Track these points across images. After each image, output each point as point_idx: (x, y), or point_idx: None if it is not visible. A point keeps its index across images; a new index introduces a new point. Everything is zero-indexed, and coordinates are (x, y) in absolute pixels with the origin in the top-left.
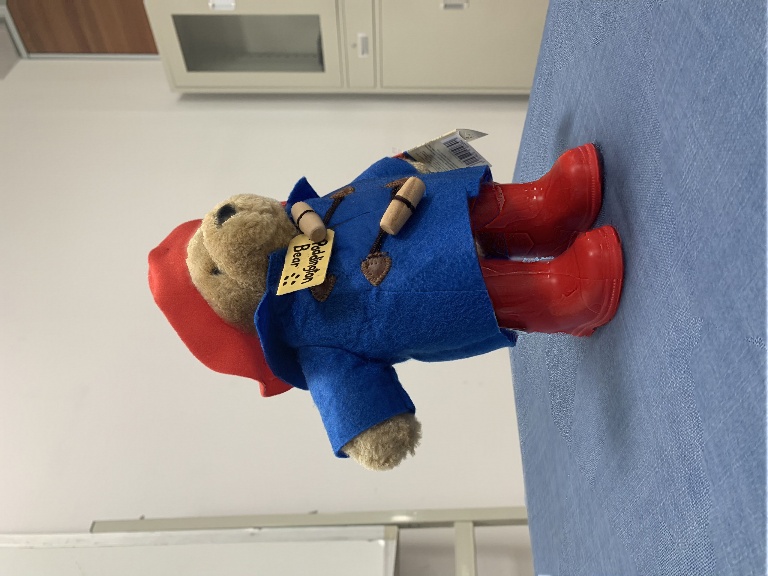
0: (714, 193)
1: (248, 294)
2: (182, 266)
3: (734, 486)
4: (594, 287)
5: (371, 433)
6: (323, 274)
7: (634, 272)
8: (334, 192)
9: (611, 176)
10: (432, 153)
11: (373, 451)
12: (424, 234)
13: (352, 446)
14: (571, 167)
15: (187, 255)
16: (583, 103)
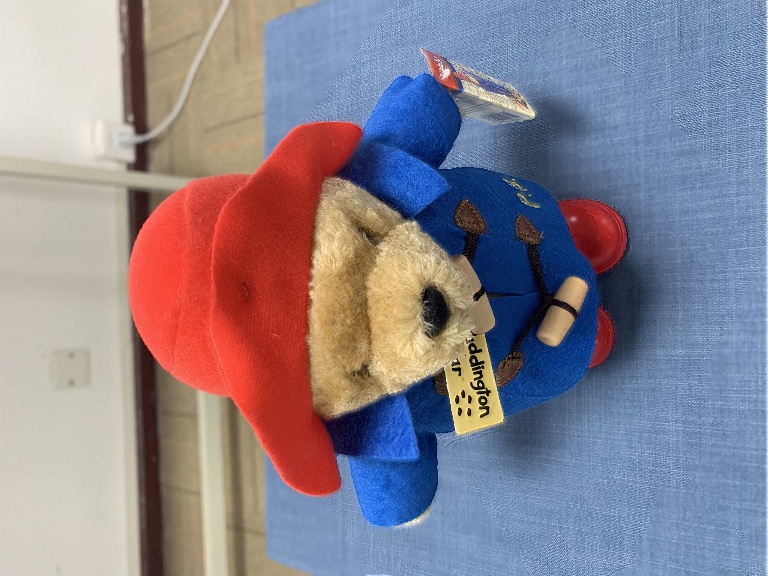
0: (761, 433)
1: None
2: (300, 348)
3: (665, 574)
4: None
5: (426, 511)
6: (498, 403)
7: (620, 376)
8: (446, 197)
9: (630, 274)
10: (479, 104)
11: None
12: None
13: None
14: (608, 243)
15: (306, 324)
16: (616, 144)
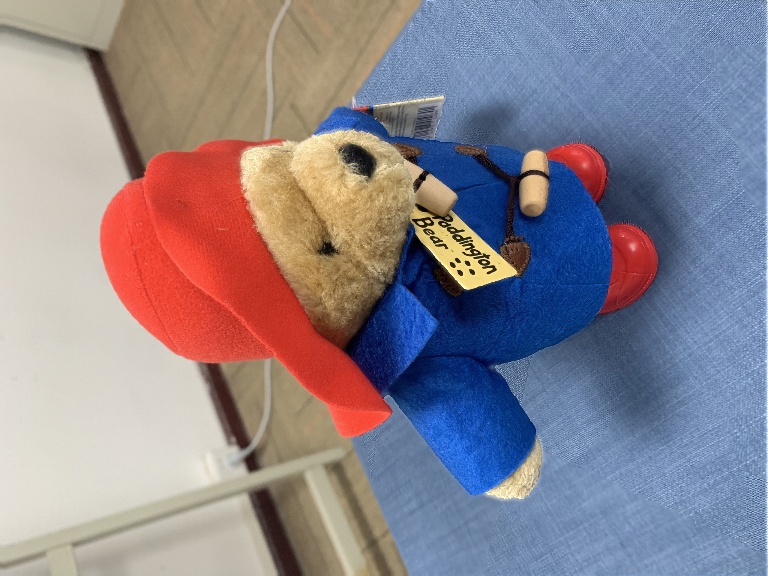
0: None
1: (372, 286)
2: (251, 236)
3: None
4: (633, 280)
5: (534, 455)
6: (504, 261)
7: (682, 269)
8: None
9: (624, 179)
10: (397, 116)
11: (532, 476)
12: (557, 219)
13: (511, 476)
14: (582, 164)
15: (249, 217)
16: (544, 101)
